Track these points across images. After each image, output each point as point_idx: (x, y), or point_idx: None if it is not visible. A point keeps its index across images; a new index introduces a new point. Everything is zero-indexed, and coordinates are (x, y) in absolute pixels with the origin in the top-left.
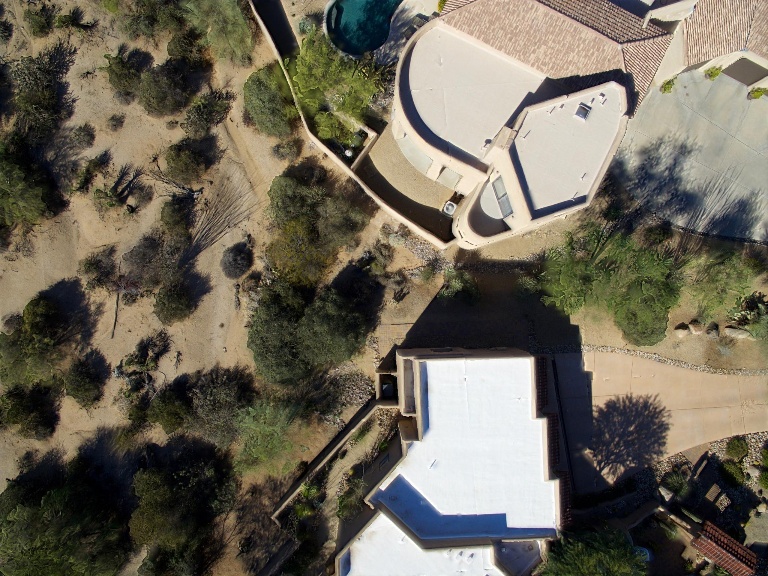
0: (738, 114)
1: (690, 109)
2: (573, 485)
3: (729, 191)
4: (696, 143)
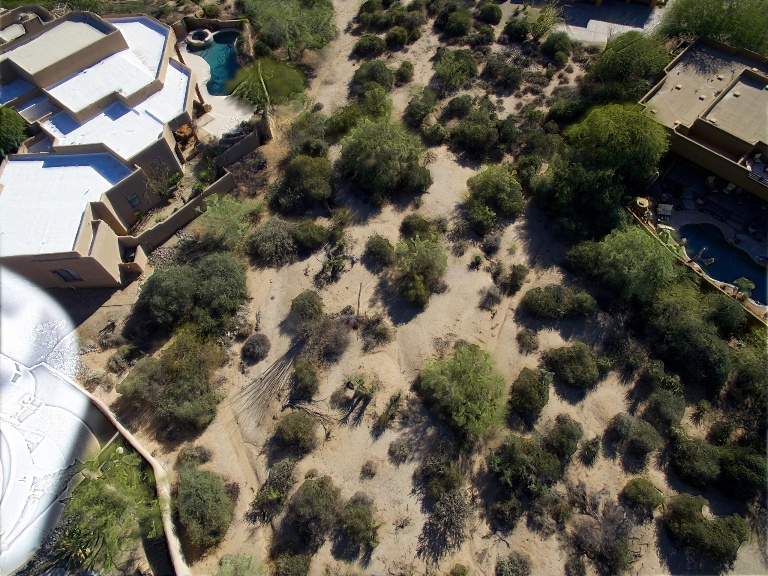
0: None
1: None
2: None
3: None
4: None
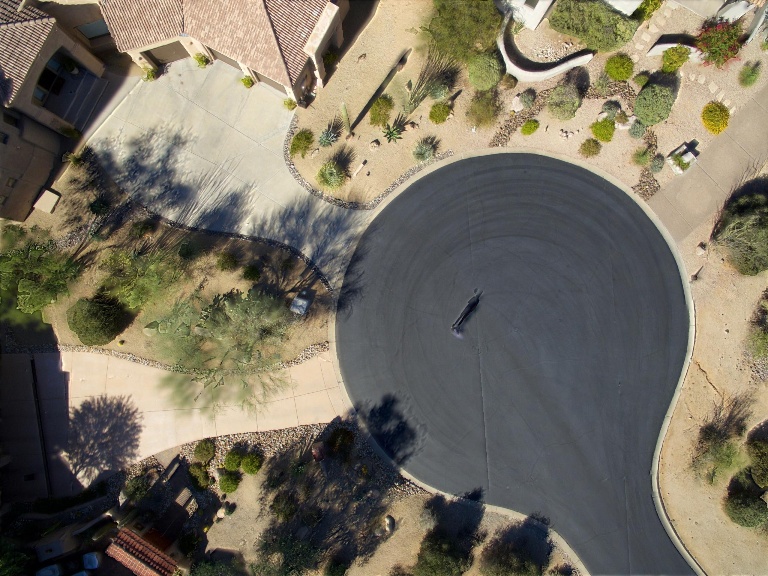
0: (237, 103)
1: (185, 98)
2: (50, 489)
3: (224, 184)
4: (191, 134)
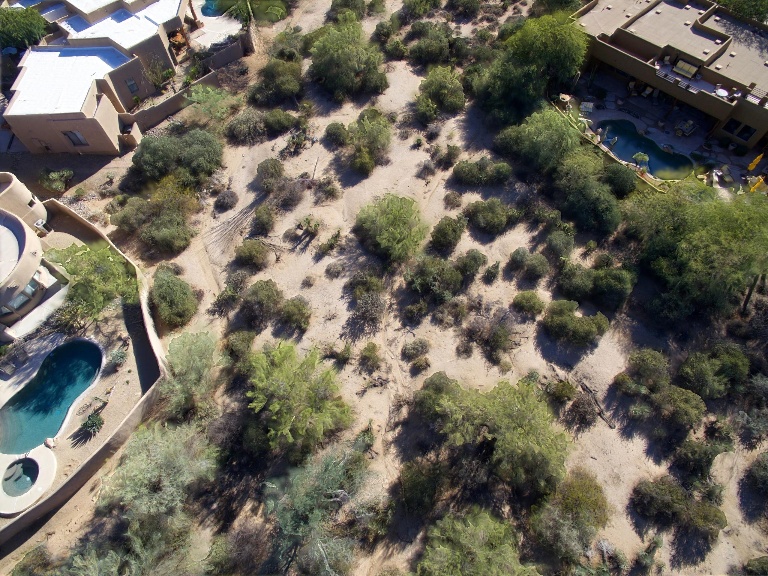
0: None
1: None
2: None
3: None
4: None
